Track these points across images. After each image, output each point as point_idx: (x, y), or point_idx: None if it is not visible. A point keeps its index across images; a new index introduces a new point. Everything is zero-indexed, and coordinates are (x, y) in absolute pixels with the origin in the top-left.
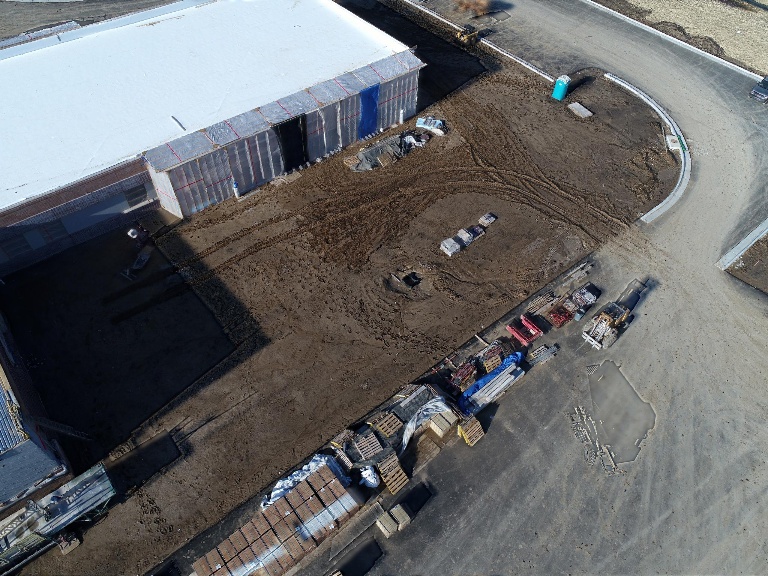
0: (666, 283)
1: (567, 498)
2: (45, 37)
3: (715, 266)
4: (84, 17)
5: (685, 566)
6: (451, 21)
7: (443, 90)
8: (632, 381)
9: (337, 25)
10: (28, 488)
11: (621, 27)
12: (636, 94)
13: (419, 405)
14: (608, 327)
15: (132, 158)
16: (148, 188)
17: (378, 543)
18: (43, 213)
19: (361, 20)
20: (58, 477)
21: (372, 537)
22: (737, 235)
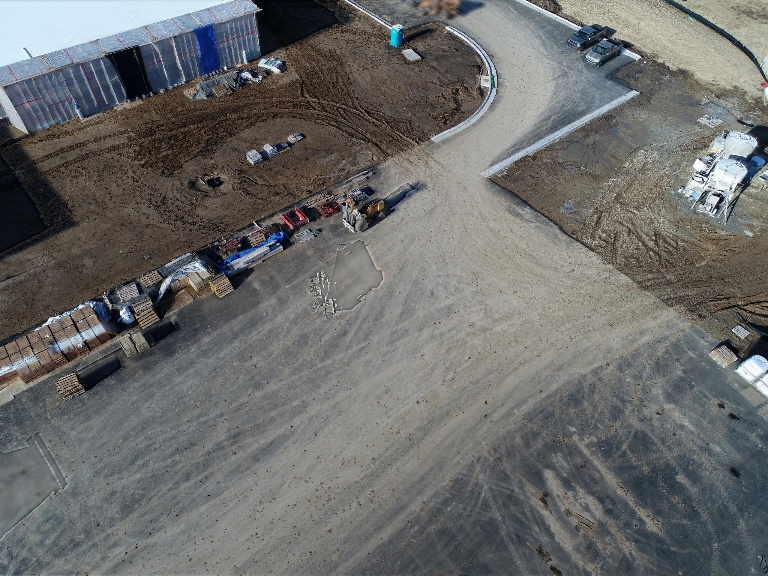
0: (433, 186)
1: (286, 333)
2: None
3: (480, 174)
4: None
5: (363, 378)
6: None
7: (293, 38)
8: (373, 255)
9: None
10: None
11: None
12: (468, 43)
13: (181, 266)
14: (357, 212)
15: None
16: None
17: (120, 361)
18: None
19: None
20: None
21: (116, 357)
22: (510, 152)
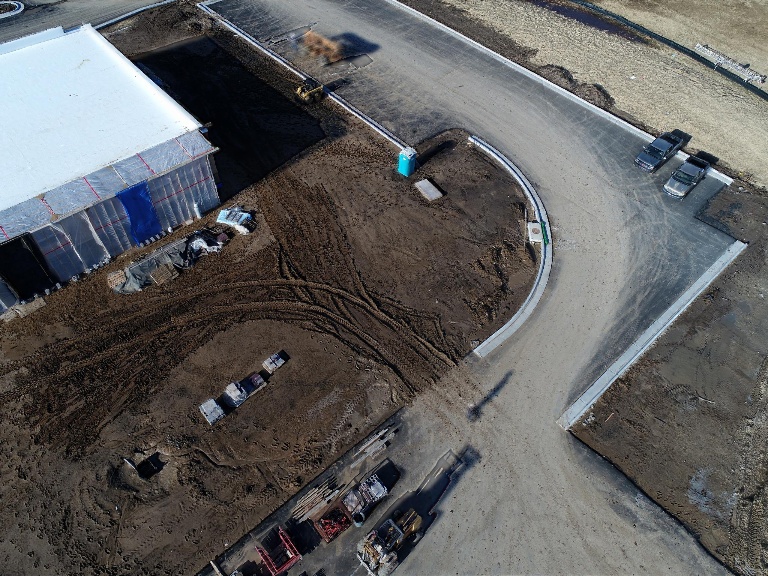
0: (488, 455)
1: None
2: None
3: (556, 424)
4: None
5: None
6: (299, 70)
7: (265, 167)
8: None
9: (125, 92)
10: None
11: (499, 73)
12: (502, 164)
13: None
14: (382, 554)
15: None
16: None
17: None
18: None
19: (154, 86)
20: None
21: None
22: (592, 372)
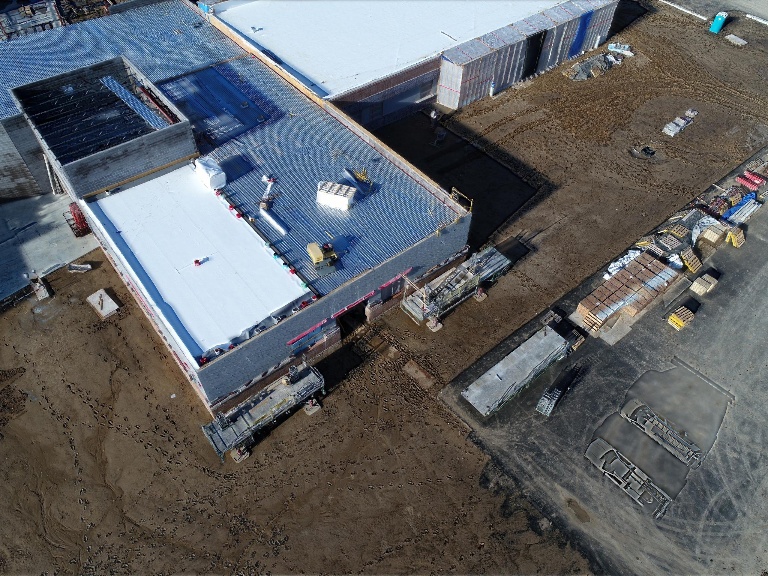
0: None
1: None
2: None
3: None
4: None
5: None
6: None
7: (619, 25)
8: None
9: None
10: (449, 258)
11: None
12: None
13: (696, 220)
14: None
15: (434, 56)
16: (434, 84)
17: (695, 299)
18: (378, 94)
19: None
20: (463, 254)
21: (690, 295)
22: None
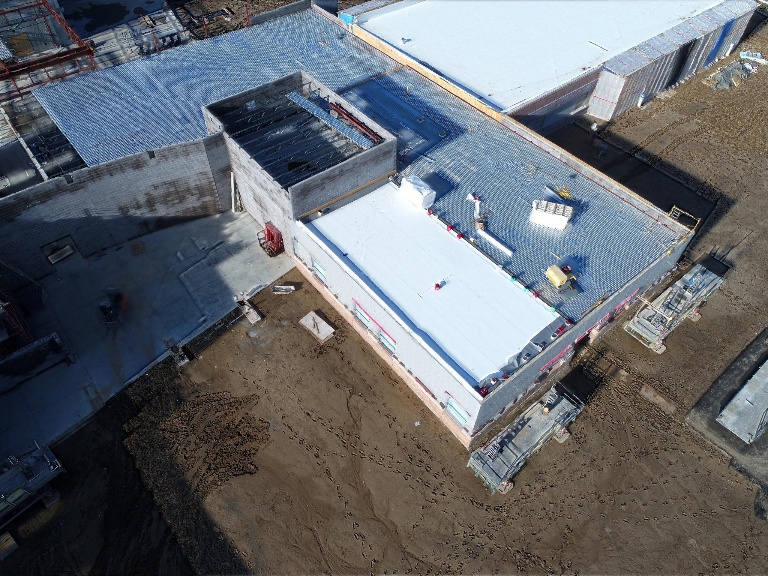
0: None
1: None
2: None
3: None
4: None
5: None
6: None
7: None
8: None
9: None
10: (660, 277)
11: None
12: None
13: None
14: None
15: (595, 67)
16: (588, 95)
17: None
18: (545, 106)
19: None
20: None
21: None
22: None
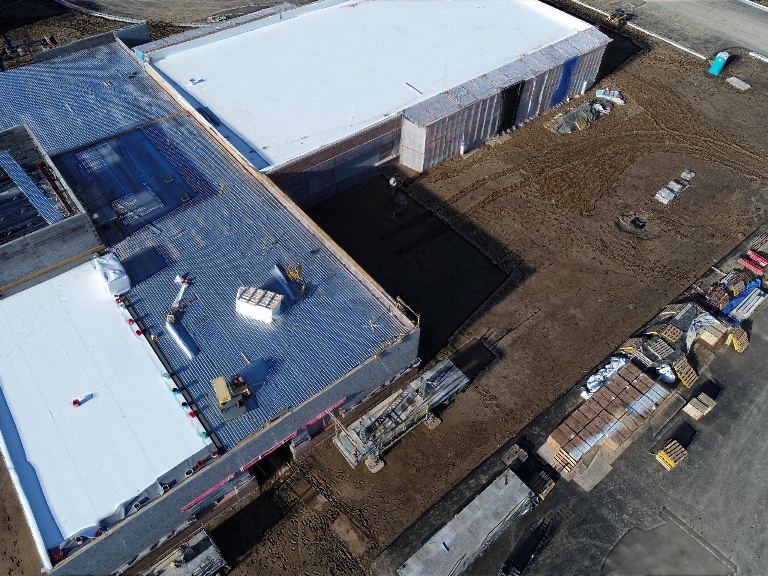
0: None
1: None
2: (270, 15)
3: None
4: (258, 3)
5: None
6: (594, 6)
7: (609, 66)
8: None
9: (516, 6)
10: (395, 375)
11: (751, 12)
12: None
13: (691, 318)
14: None
15: (393, 115)
16: (395, 144)
17: (689, 424)
18: (327, 161)
19: (539, 2)
20: (413, 369)
21: (683, 419)
22: None
